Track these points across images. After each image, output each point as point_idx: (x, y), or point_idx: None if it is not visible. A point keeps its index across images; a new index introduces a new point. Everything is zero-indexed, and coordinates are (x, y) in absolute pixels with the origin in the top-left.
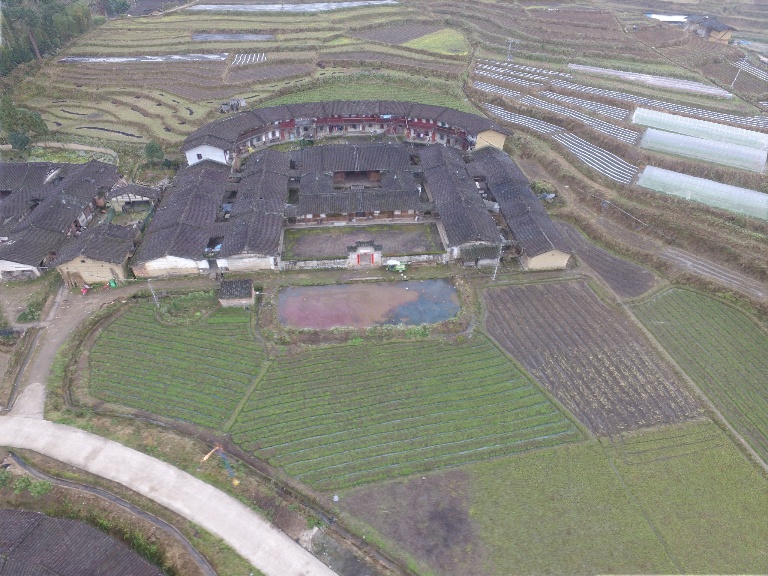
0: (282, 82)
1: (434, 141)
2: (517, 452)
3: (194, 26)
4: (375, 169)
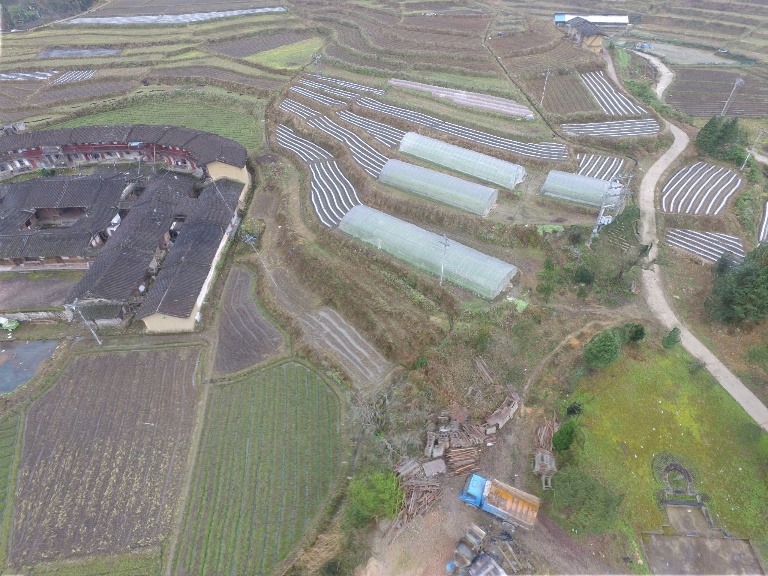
0: (89, 102)
1: (194, 169)
2: None
3: (51, 42)
4: (75, 206)
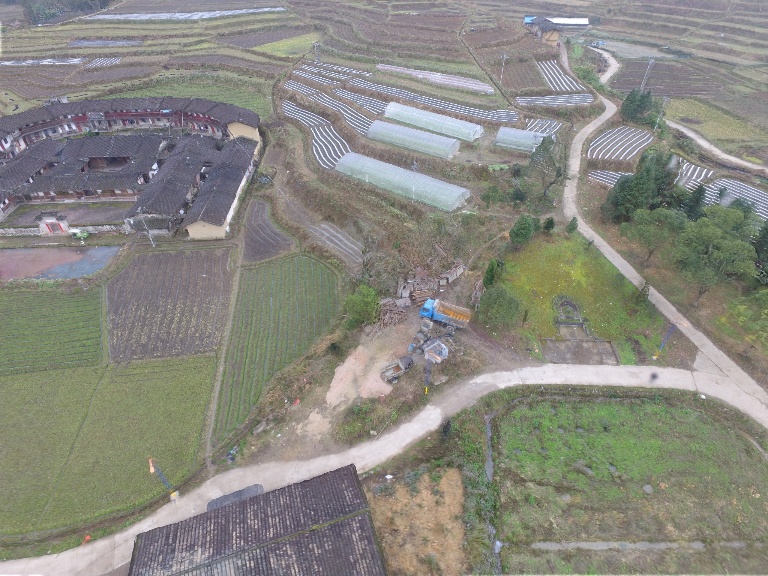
0: (119, 82)
1: (214, 133)
2: (36, 371)
3: (78, 34)
4: (122, 155)
